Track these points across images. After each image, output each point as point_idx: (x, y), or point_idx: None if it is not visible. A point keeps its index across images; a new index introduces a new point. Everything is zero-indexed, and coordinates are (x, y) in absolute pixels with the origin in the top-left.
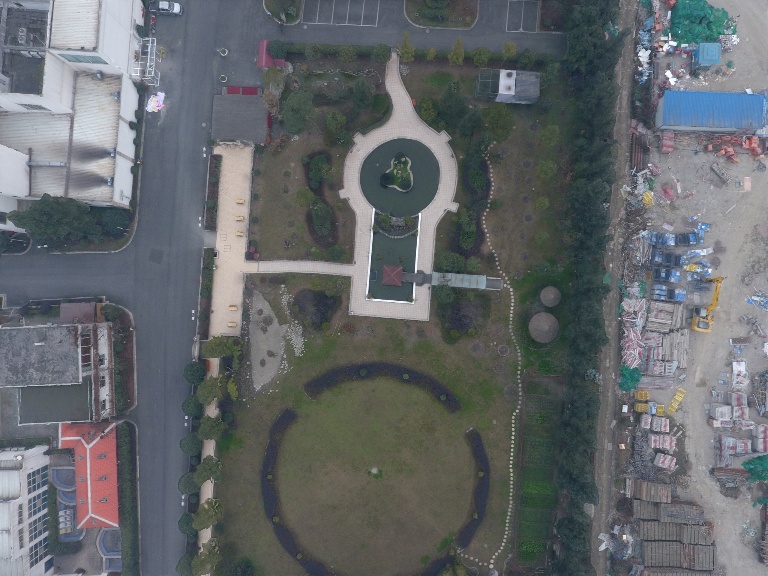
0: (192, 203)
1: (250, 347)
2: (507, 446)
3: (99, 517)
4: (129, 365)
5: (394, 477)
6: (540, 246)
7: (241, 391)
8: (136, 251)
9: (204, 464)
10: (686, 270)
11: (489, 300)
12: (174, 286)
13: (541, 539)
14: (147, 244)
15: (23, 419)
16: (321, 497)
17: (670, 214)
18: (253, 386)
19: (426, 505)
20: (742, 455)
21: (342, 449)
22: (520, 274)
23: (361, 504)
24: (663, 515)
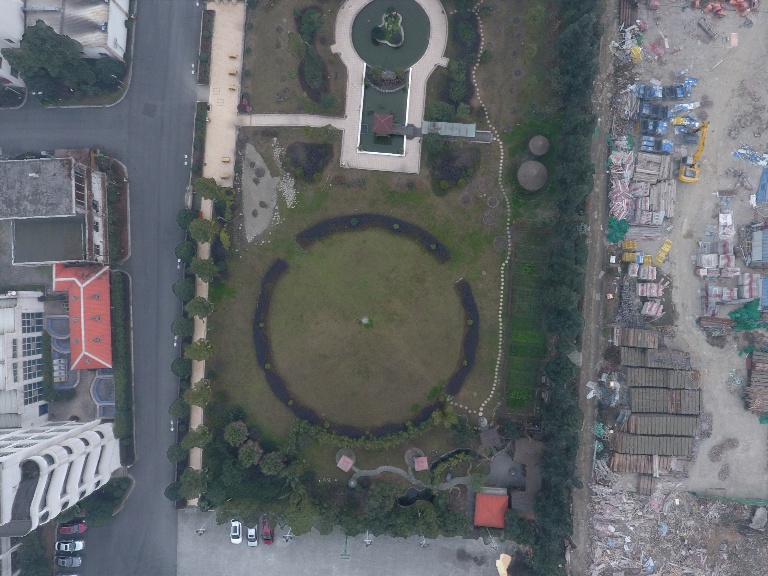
0: (185, 58)
1: (242, 199)
2: (496, 296)
3: (93, 356)
4: (123, 216)
5: (385, 327)
6: (529, 100)
7: (233, 241)
8: (130, 105)
9: (196, 299)
10: (673, 123)
11: (479, 152)
12: (167, 140)
13: (530, 387)
14: (141, 98)
15: (18, 258)
16: (312, 346)
17: (658, 69)
18: (245, 237)
19: (416, 354)
20: (728, 301)
21: (333, 299)
22: (509, 128)
23: (352, 353)
24: (650, 360)
